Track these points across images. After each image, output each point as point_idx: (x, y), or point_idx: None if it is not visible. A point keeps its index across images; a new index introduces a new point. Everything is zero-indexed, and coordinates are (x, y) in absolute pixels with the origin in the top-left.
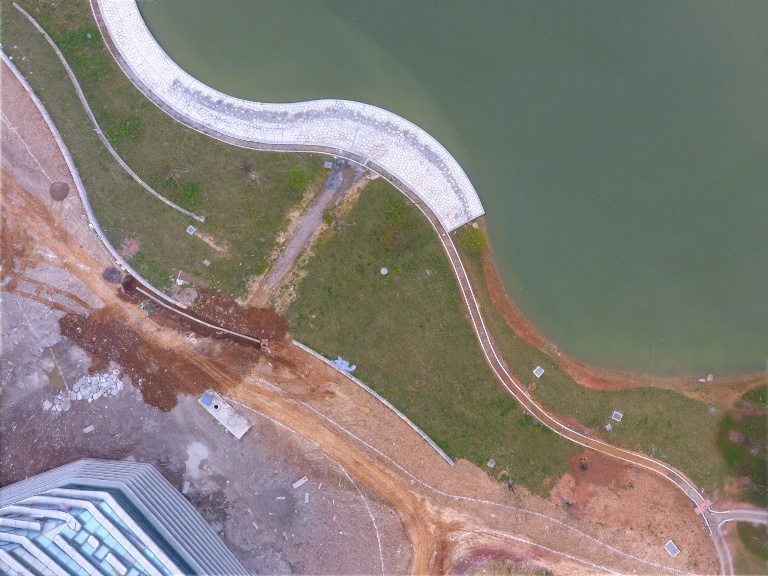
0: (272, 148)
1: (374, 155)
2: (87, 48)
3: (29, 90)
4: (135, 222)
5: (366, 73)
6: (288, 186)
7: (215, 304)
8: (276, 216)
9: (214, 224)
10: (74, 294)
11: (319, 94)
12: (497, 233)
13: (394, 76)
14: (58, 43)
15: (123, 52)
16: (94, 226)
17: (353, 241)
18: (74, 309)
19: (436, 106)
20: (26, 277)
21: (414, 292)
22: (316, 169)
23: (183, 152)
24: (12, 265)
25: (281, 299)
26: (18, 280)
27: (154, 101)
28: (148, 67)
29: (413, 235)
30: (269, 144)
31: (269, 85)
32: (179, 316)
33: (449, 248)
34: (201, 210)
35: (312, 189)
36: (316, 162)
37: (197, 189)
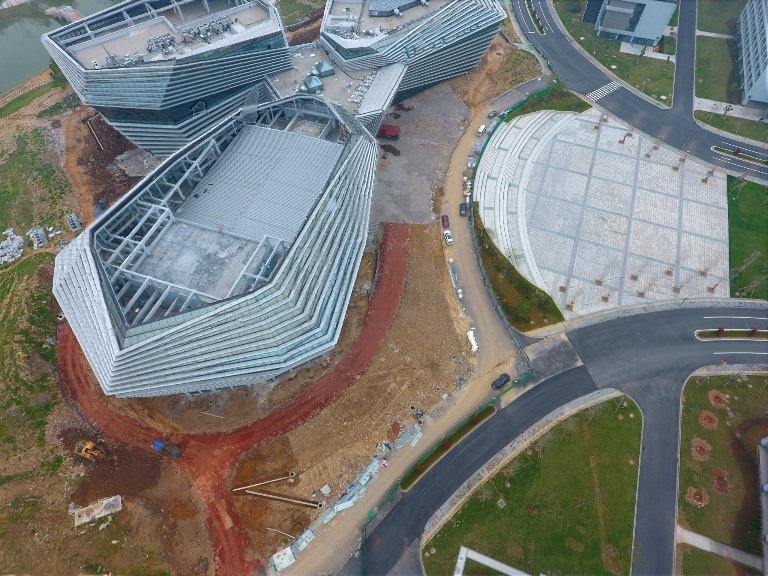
0: None
1: None
2: None
3: None
4: None
5: None
6: None
7: None
8: (296, 4)
9: None
10: None
11: None
12: None
13: None
14: None
15: None
16: None
17: None
18: None
19: None
20: None
21: None
22: None
23: None
24: None
25: None
26: None
27: None
28: None
29: None
30: None
31: None
32: None
33: None
34: None
35: None
36: None
37: None
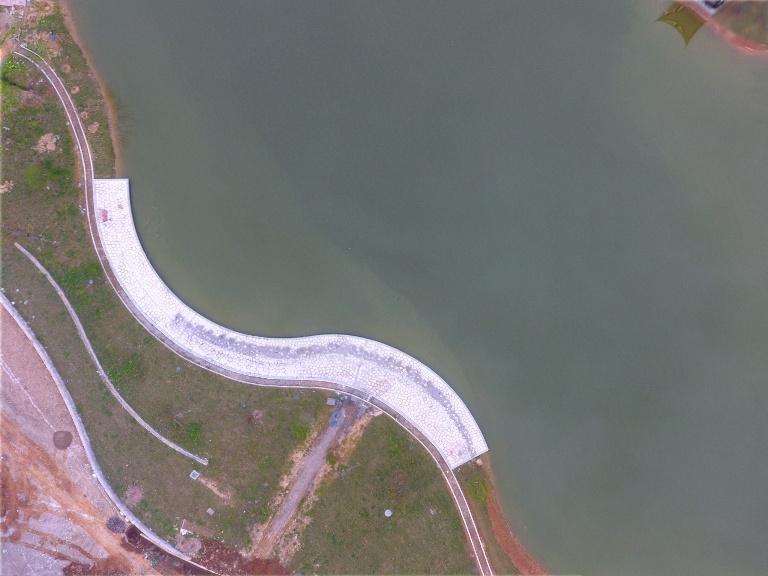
0: (275, 383)
1: (377, 391)
2: (89, 285)
3: (31, 338)
4: (138, 468)
5: (368, 308)
6: (291, 425)
7: (219, 560)
8: (279, 458)
9: (217, 468)
10: (78, 545)
11: (321, 329)
12: (501, 469)
13: (396, 310)
14: (60, 282)
15: (125, 286)
16: (97, 476)
17: (357, 483)
18: (78, 559)
19: (439, 340)
20: (30, 528)
21: (418, 535)
22: (319, 406)
23: (186, 390)
24: (16, 516)
25: (285, 549)
26: (22, 531)
27: (156, 335)
28: (150, 301)
29: (417, 473)
30: (272, 379)
31: (271, 320)
32: (183, 562)
33: (453, 485)
34: (204, 451)
35: (315, 428)
36: (319, 398)
37: (200, 429)
